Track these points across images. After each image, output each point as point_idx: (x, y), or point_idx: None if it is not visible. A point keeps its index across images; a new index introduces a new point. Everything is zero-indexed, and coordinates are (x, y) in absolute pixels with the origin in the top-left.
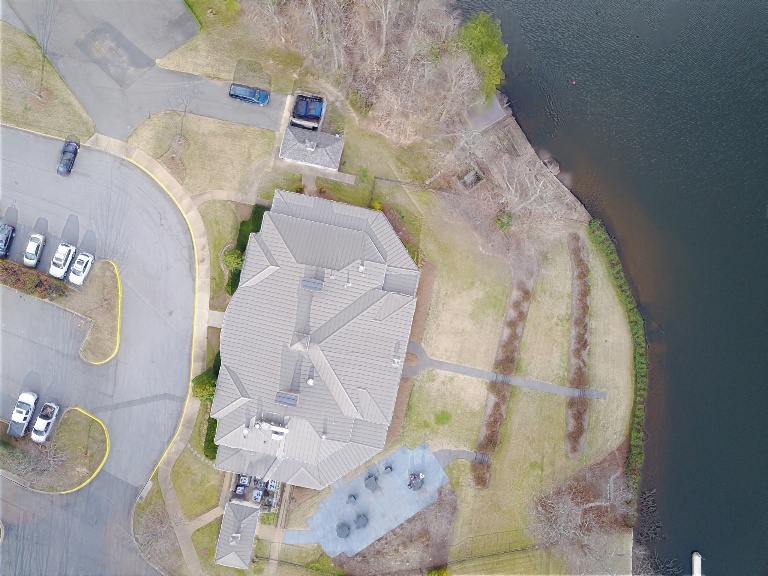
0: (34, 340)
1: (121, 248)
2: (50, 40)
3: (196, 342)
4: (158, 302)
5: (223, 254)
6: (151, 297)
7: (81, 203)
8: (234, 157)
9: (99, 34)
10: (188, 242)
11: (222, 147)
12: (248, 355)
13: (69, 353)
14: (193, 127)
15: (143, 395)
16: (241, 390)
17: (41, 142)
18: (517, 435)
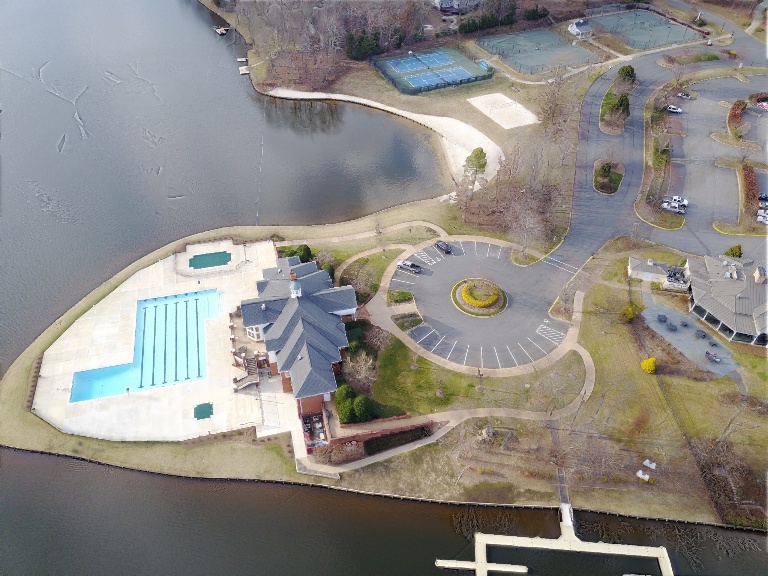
0: (715, 207)
1: None
2: None
3: None
4: (763, 249)
5: None
6: (764, 247)
7: None
8: None
9: None
10: None
11: None
12: (767, 269)
13: (714, 218)
14: None
15: (705, 242)
16: (746, 264)
17: None
18: None
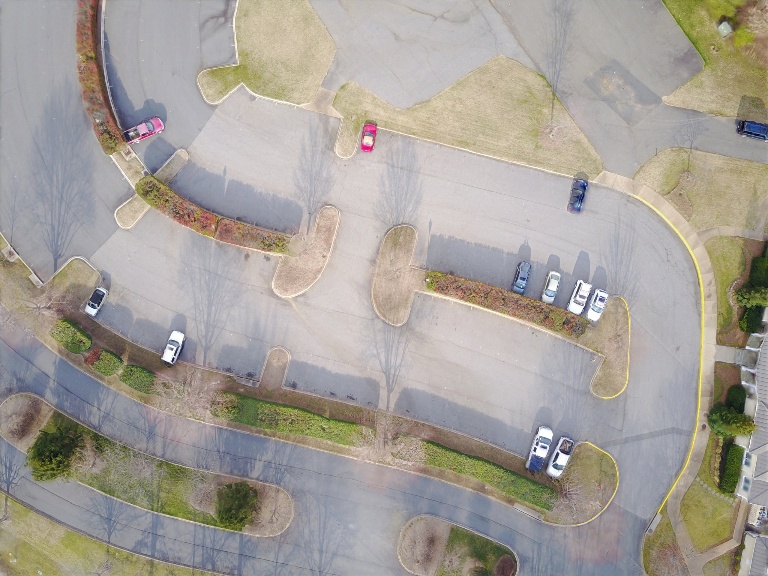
0: (546, 375)
1: (630, 284)
2: (560, 78)
3: (703, 377)
4: (666, 337)
5: (733, 290)
6: (659, 332)
7: (591, 240)
8: (740, 193)
9: (607, 72)
10: (694, 278)
11: (728, 183)
12: None
13: (580, 388)
14: (699, 164)
15: (652, 429)
16: None
17: (550, 180)
18: None
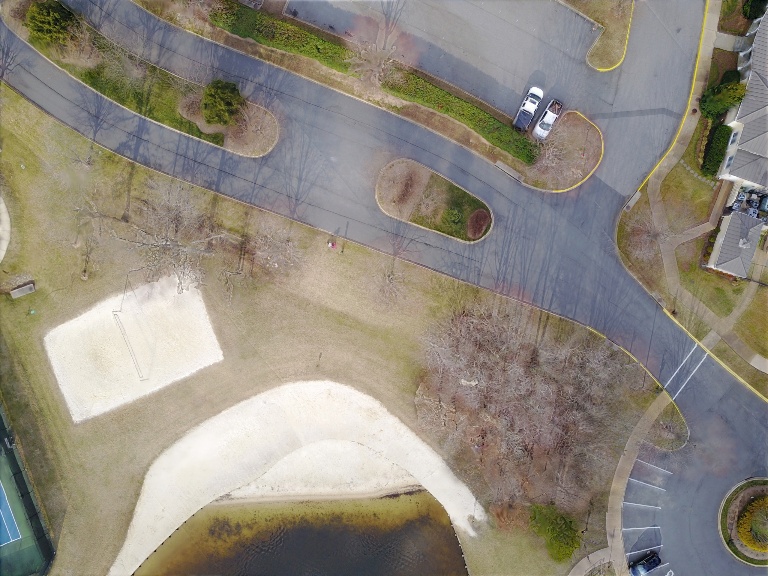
0: (544, 40)
1: None
2: None
3: (700, 61)
4: (668, 18)
5: None
6: (662, 12)
7: None
8: None
9: None
10: None
11: None
12: None
13: (576, 57)
14: None
15: (642, 107)
16: None
17: None
18: None
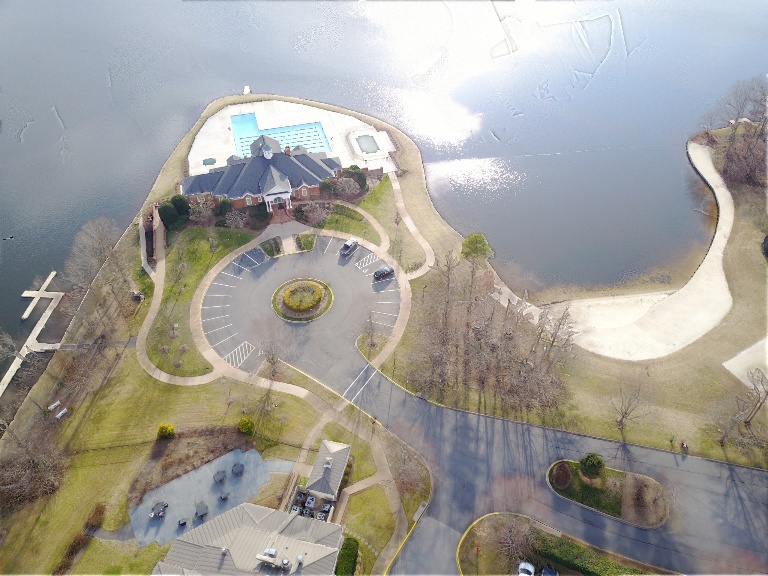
0: None
1: None
2: None
3: None
4: None
5: None
6: None
7: None
8: None
9: None
10: None
11: None
12: None
13: None
14: None
15: None
16: None
17: None
18: (47, 554)
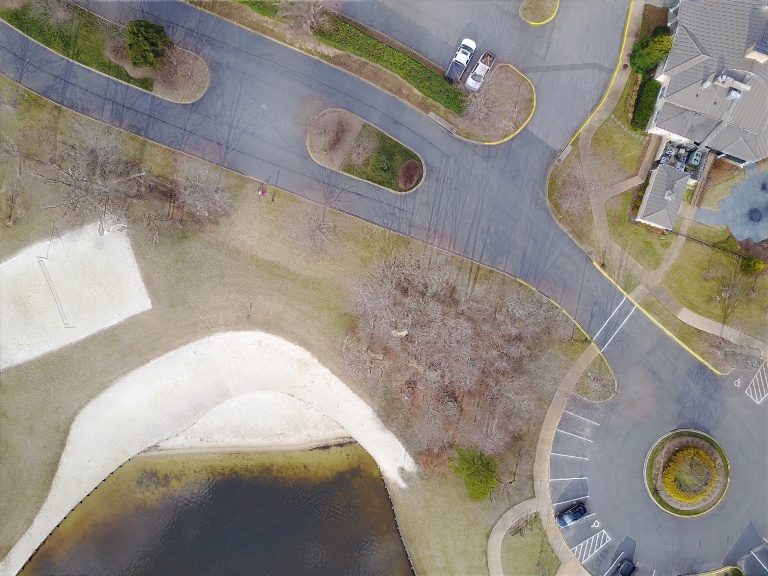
0: None
1: None
2: None
3: (632, 17)
4: None
5: None
6: None
7: None
8: None
9: None
10: None
11: None
12: (709, 17)
13: (509, 10)
14: None
15: (574, 61)
16: (701, 48)
17: None
18: None
